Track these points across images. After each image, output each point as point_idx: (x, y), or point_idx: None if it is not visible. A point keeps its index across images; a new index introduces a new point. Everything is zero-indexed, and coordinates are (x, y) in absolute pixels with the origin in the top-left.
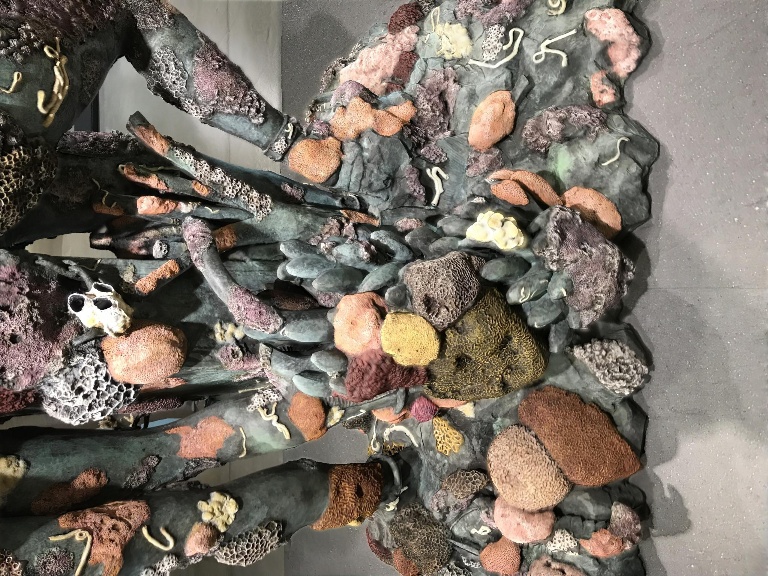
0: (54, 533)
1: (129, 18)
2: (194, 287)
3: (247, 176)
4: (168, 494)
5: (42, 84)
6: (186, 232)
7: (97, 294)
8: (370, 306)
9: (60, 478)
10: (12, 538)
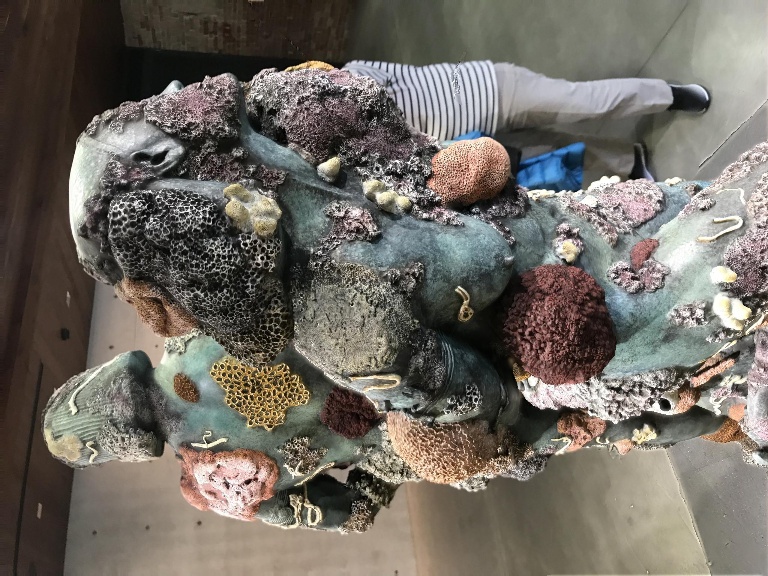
0: (554, 437)
1: None
2: None
3: None
4: None
5: None
6: (761, 353)
7: None
8: None
9: None
10: (533, 435)
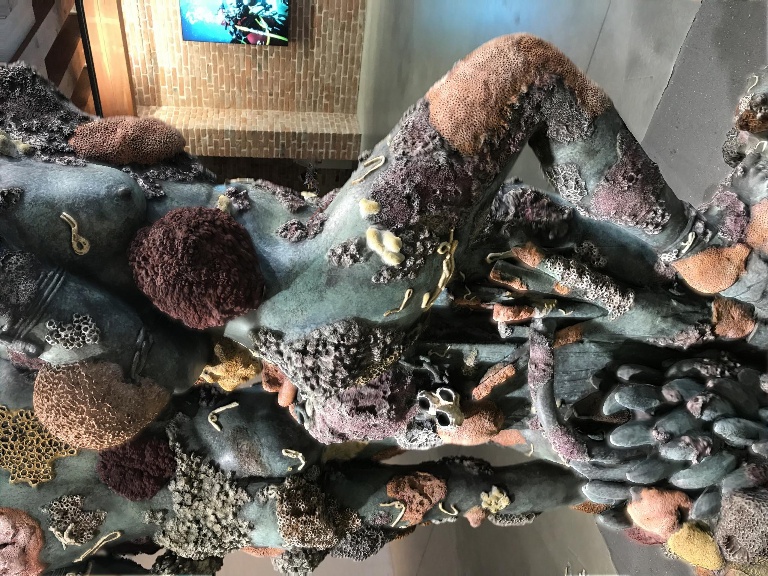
0: (383, 501)
1: (540, 126)
2: (525, 368)
3: (620, 251)
4: (462, 475)
5: (429, 286)
6: (531, 350)
7: (441, 400)
8: (673, 511)
9: (392, 444)
10: (358, 499)
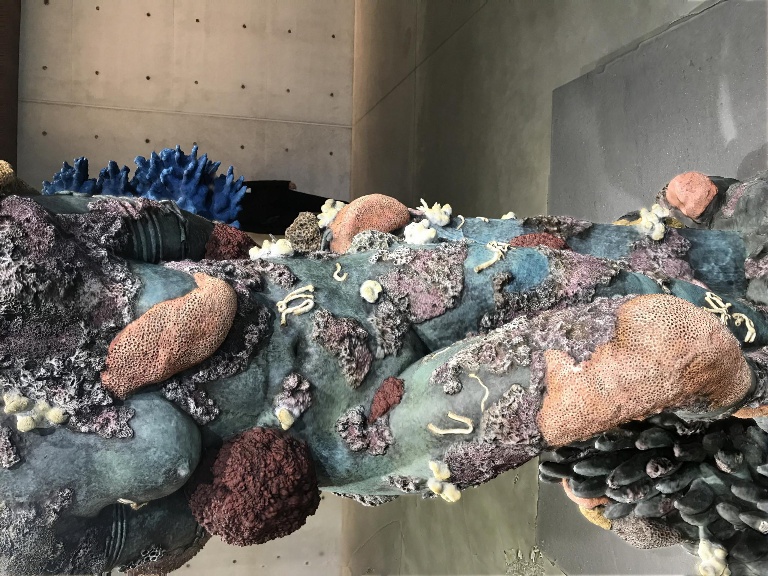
0: None
1: None
2: None
3: None
4: None
5: None
6: None
7: None
8: None
9: None
10: None
